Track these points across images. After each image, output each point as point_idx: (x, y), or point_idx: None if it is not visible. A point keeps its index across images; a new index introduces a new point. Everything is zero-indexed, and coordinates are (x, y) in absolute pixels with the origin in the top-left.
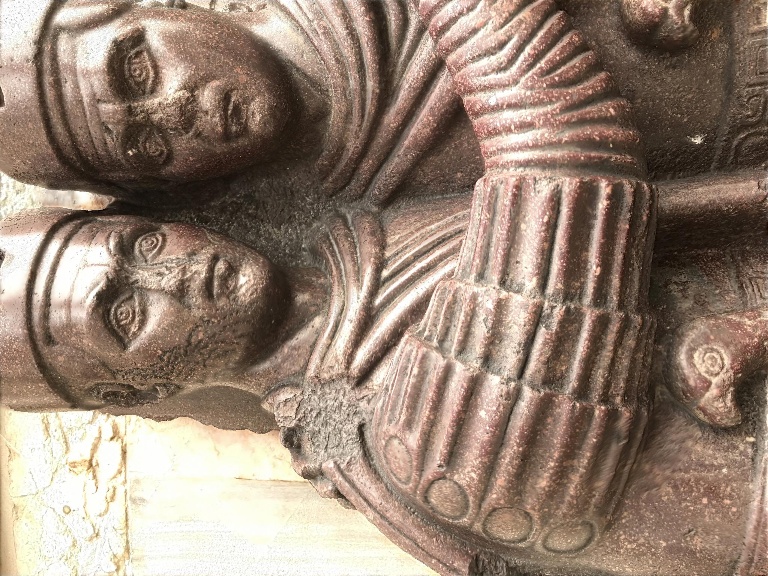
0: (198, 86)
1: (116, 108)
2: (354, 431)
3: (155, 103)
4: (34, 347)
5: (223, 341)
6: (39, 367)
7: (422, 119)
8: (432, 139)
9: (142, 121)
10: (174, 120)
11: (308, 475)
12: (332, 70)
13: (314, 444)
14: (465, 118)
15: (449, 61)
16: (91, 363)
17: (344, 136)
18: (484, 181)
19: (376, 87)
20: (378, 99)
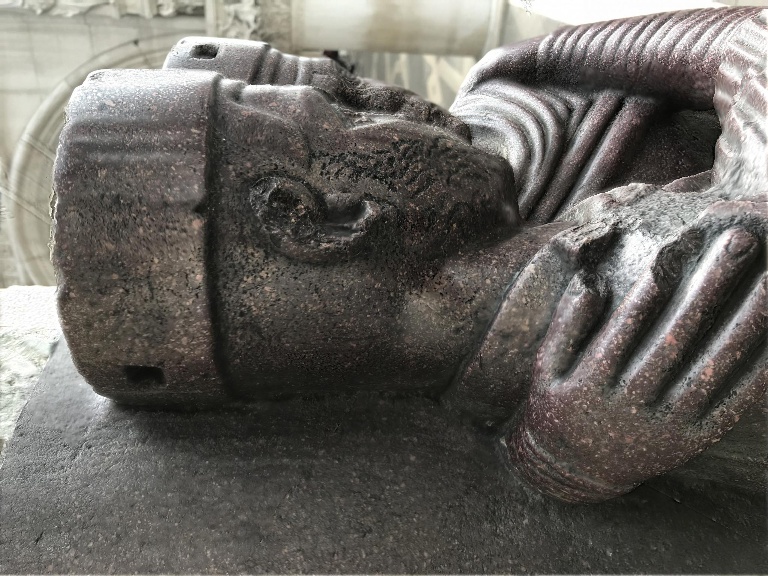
0: (404, 96)
1: (331, 77)
2: (718, 199)
3: (365, 89)
4: (213, 93)
5: (474, 163)
6: (208, 110)
7: (603, 150)
8: (614, 166)
9: (350, 95)
10: (383, 99)
11: (665, 279)
12: (509, 133)
13: (658, 234)
14: (639, 155)
15: (649, 44)
16: (289, 129)
17: (521, 178)
18: (737, 34)
19: (555, 133)
20: (557, 142)
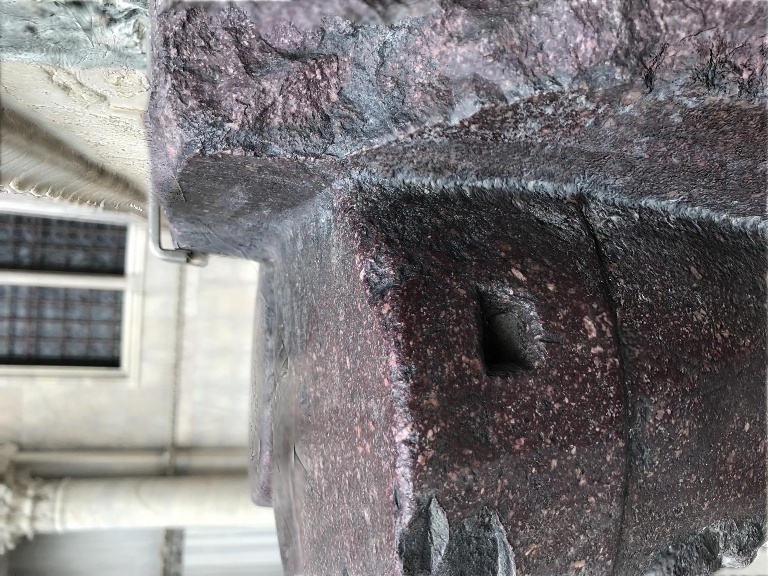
0: None
1: None
2: None
3: None
4: None
5: None
6: None
7: None
8: None
9: None
10: None
11: None
12: None
13: None
14: None
15: None
16: None
17: None
18: None
19: None
20: None
